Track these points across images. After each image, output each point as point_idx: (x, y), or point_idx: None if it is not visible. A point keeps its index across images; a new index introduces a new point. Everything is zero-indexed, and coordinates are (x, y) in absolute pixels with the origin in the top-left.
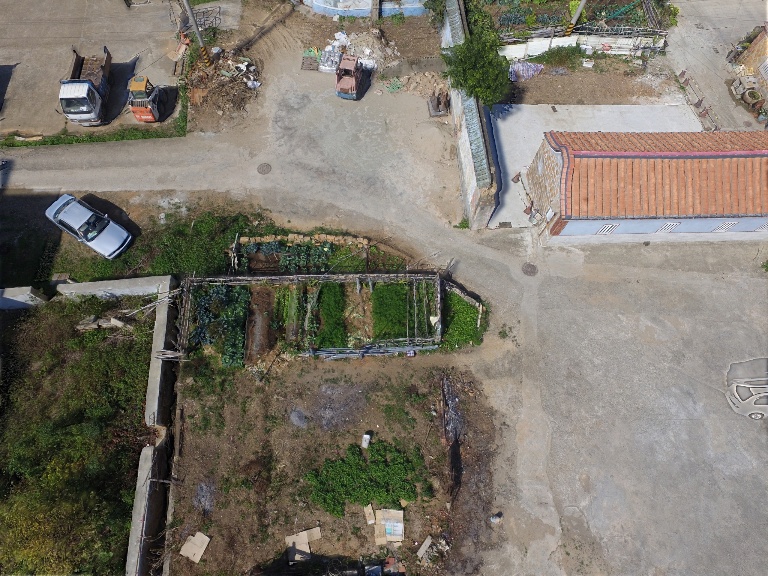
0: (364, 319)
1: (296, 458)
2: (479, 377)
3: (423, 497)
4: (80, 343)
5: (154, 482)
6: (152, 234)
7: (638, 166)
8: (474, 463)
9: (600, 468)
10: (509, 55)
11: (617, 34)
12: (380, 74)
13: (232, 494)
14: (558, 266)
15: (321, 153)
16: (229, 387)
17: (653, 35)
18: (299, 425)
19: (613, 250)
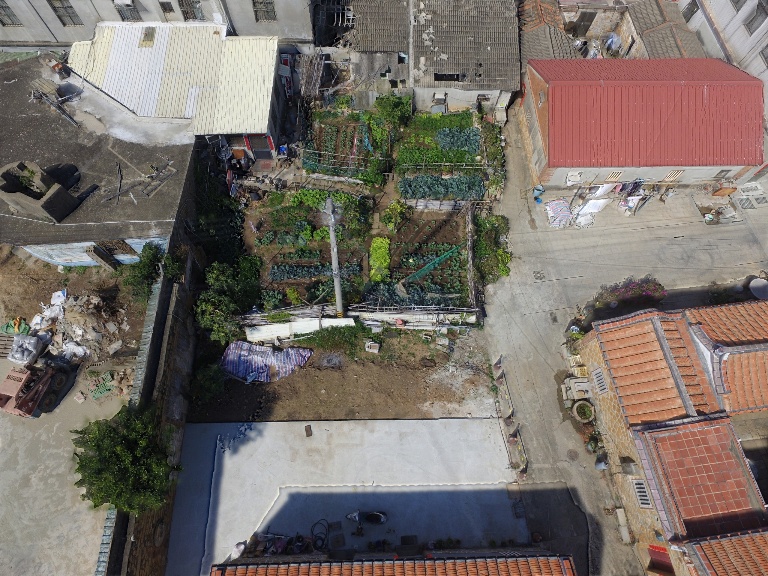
0: None
1: None
2: None
3: None
4: None
5: None
6: None
7: None
8: None
9: None
10: (269, 334)
11: (410, 310)
12: (86, 370)
13: None
14: None
15: None
16: None
17: (460, 311)
18: None
19: None
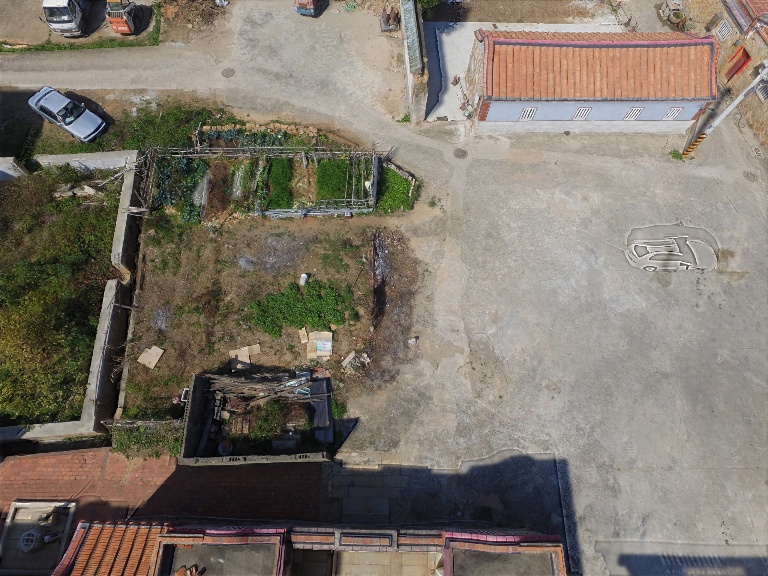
0: (309, 188)
1: (242, 292)
2: (408, 235)
3: (350, 321)
4: (57, 206)
5: (117, 306)
6: (124, 123)
7: (552, 53)
8: (397, 299)
9: (508, 305)
10: None
11: None
12: None
13: (185, 318)
14: (486, 151)
15: (280, 60)
16: (186, 238)
17: None
18: (246, 267)
19: (536, 138)
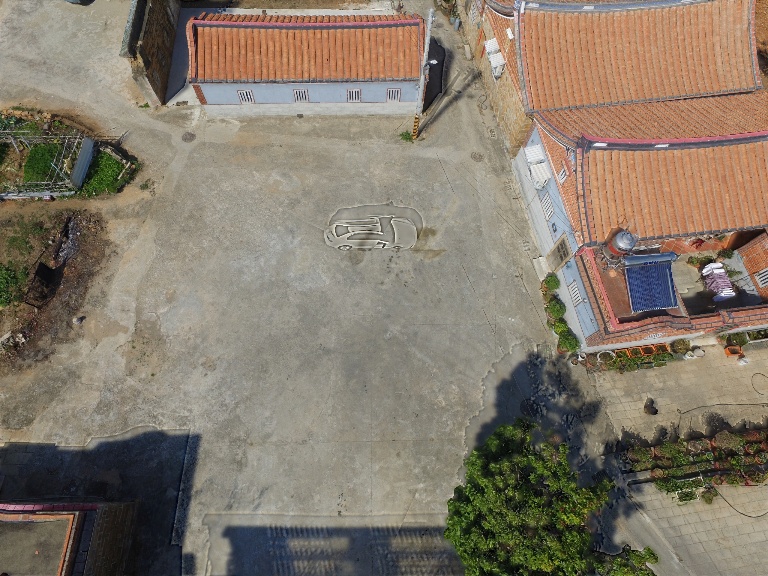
0: (18, 173)
1: None
2: (107, 218)
3: (14, 302)
4: None
5: None
6: None
7: (257, 35)
8: (74, 280)
9: (188, 285)
10: None
11: None
12: None
13: None
14: (214, 134)
15: (38, 48)
16: None
17: None
18: None
19: (268, 121)
